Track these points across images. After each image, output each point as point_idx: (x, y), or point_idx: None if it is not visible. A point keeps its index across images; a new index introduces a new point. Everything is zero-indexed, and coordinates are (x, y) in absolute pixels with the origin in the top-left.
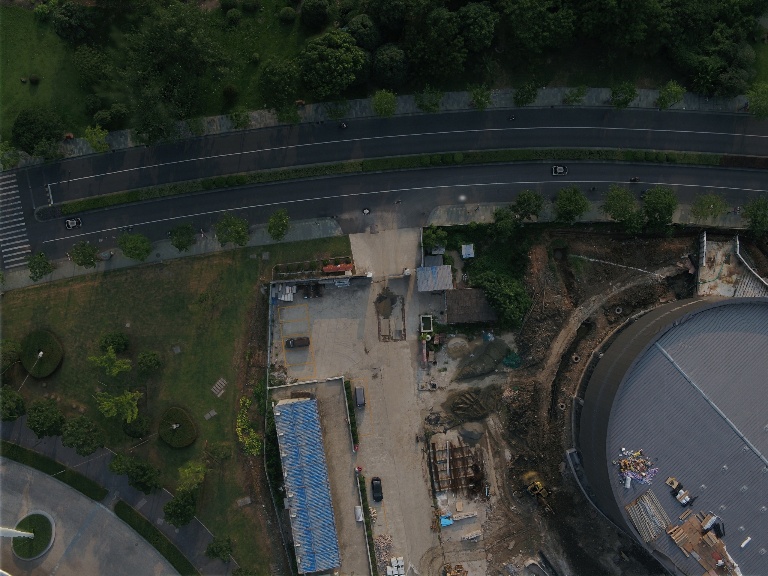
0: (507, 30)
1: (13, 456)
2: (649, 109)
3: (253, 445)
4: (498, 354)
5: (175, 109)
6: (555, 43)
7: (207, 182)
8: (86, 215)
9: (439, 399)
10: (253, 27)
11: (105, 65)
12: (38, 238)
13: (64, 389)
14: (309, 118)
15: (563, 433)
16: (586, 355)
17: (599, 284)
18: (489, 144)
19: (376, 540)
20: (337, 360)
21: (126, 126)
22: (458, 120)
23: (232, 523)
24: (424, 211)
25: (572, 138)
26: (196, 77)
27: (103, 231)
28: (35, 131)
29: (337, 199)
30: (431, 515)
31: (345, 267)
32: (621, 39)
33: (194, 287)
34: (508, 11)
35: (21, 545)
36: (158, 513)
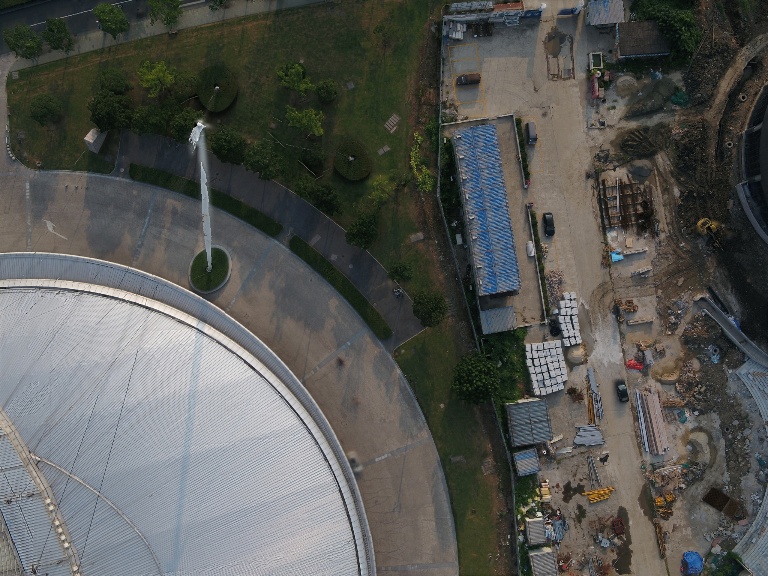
0: None
1: (189, 191)
2: None
3: (425, 181)
4: (667, 91)
5: None
6: None
7: None
8: None
9: (608, 137)
10: None
11: None
12: None
13: (238, 125)
14: None
15: (731, 171)
16: (753, 94)
17: (766, 23)
18: None
19: (548, 275)
20: (507, 98)
21: None
22: None
23: (405, 258)
24: None
25: None
26: None
27: None
28: None
29: None
30: (601, 251)
31: (515, 4)
32: None
33: (366, 25)
34: None
35: (199, 277)
36: (332, 249)
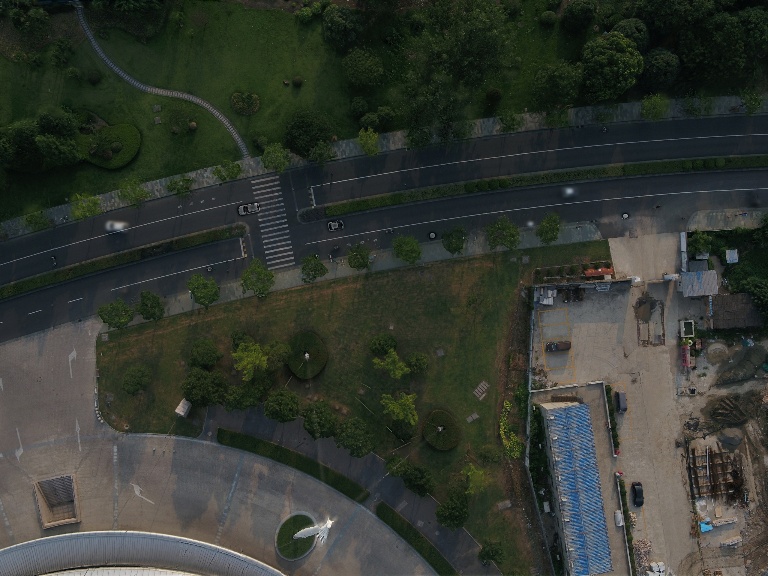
0: None
1: (277, 457)
2: None
3: (514, 448)
4: (759, 360)
5: (437, 112)
6: None
7: (471, 185)
8: (348, 217)
9: (698, 404)
10: (514, 31)
11: (377, 68)
12: (300, 240)
13: (327, 390)
14: (570, 122)
15: None
16: None
17: None
18: (749, 149)
19: (636, 545)
20: (597, 364)
21: (388, 129)
22: (718, 125)
23: (492, 526)
24: (684, 216)
25: None
26: (457, 80)
27: (365, 233)
28: (312, 134)
29: (596, 203)
30: (690, 520)
31: (607, 271)
32: None
33: (456, 290)
34: None
35: (286, 545)
36: (419, 515)
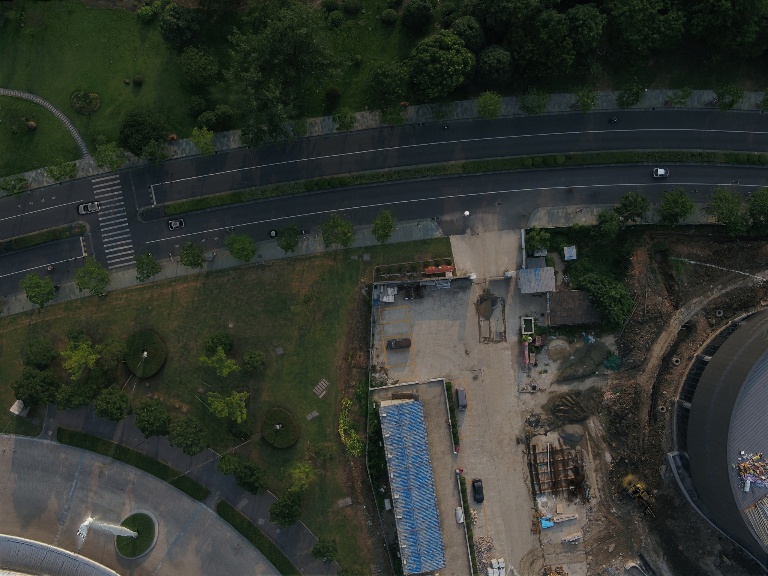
0: (611, 32)
1: (117, 455)
2: (751, 111)
3: (354, 446)
4: (599, 356)
5: (277, 110)
6: (663, 45)
7: (310, 183)
8: (189, 216)
9: (539, 401)
10: (355, 29)
11: (211, 67)
12: (141, 239)
13: (167, 389)
14: (410, 120)
15: (663, 436)
16: (687, 358)
17: (700, 287)
18: (590, 146)
19: (477, 542)
20: (438, 361)
21: (229, 127)
22: (559, 122)
23: (333, 524)
24: (525, 213)
25: (673, 140)
26: (298, 79)
27: (205, 232)
28: (143, 132)
29: (438, 201)
30: (531, 517)
31: (447, 269)
32: (731, 41)
33: (296, 288)
34: (616, 13)
35: (125, 544)
36: (259, 513)
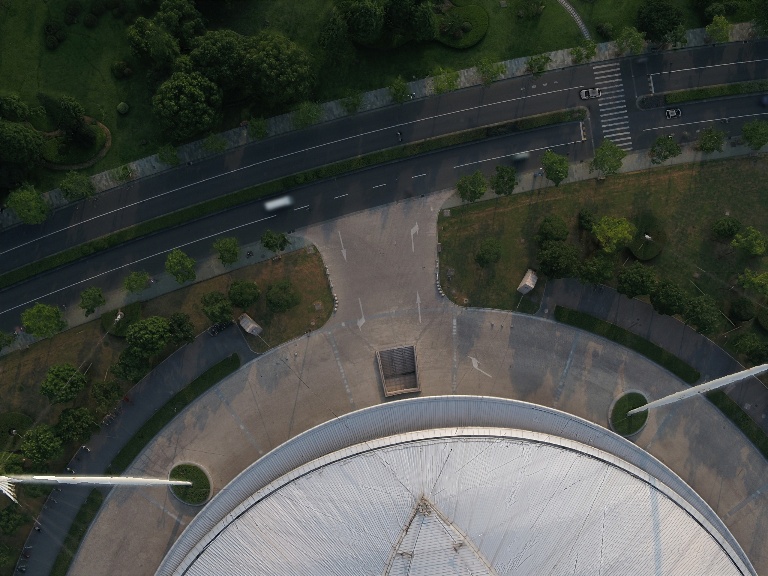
0: None
1: (613, 335)
2: None
3: None
4: None
5: None
6: None
7: None
8: (685, 106)
9: None
10: None
11: None
12: (639, 126)
13: (662, 273)
14: None
15: None
16: None
17: None
18: None
19: None
20: None
21: None
22: None
23: None
24: None
25: None
26: None
27: (701, 122)
28: (671, 17)
29: None
30: None
31: None
32: None
33: None
34: None
35: (621, 421)
36: (746, 398)
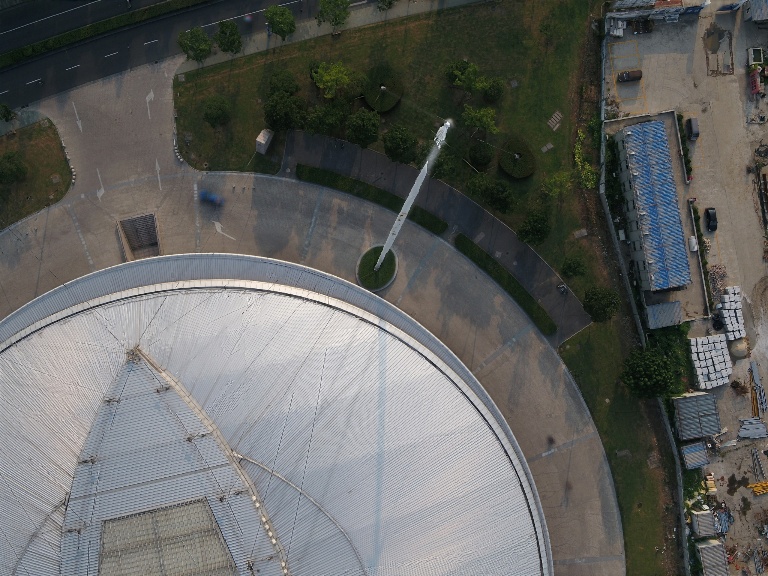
0: None
1: (356, 190)
2: None
3: (588, 178)
4: None
5: None
6: None
7: None
8: None
9: (767, 132)
10: None
11: None
12: None
13: (403, 125)
14: None
15: None
16: None
17: None
18: None
19: (710, 270)
20: (667, 94)
21: None
22: None
23: (569, 255)
24: None
25: None
26: None
27: None
28: None
29: None
30: (763, 245)
31: (676, 1)
32: None
33: (527, 23)
34: None
35: (367, 276)
36: (496, 246)
